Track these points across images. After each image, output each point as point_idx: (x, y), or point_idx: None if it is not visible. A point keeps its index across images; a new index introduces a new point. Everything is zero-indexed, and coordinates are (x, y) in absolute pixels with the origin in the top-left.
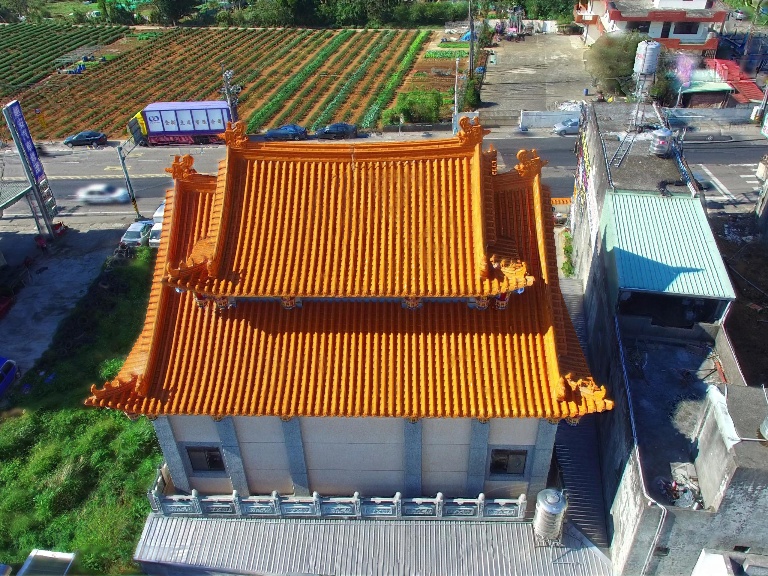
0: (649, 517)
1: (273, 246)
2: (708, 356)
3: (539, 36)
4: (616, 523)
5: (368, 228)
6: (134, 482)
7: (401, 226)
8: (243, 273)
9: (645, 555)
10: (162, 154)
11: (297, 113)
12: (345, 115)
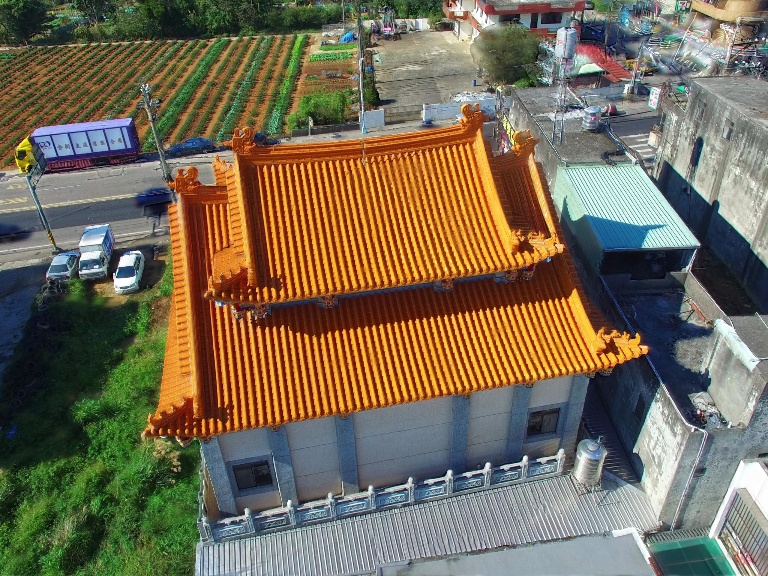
0: (692, 443)
1: (304, 248)
2: (683, 300)
3: (414, 34)
4: (646, 458)
5: (393, 219)
6: (149, 521)
7: (424, 214)
8: (282, 278)
9: (686, 479)
10: (59, 181)
11: (196, 126)
12: (248, 124)
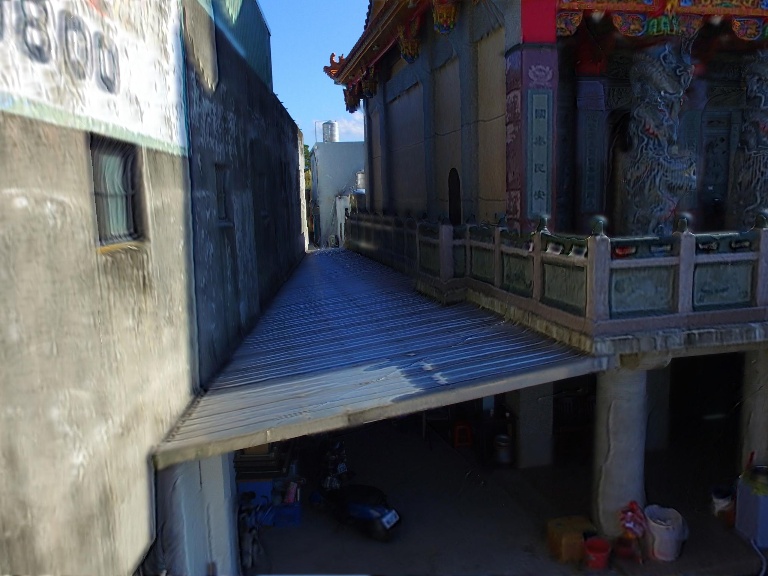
0: None
1: None
2: None
3: None
4: None
5: None
6: None
7: None
8: None
9: None
10: None
11: None
12: None
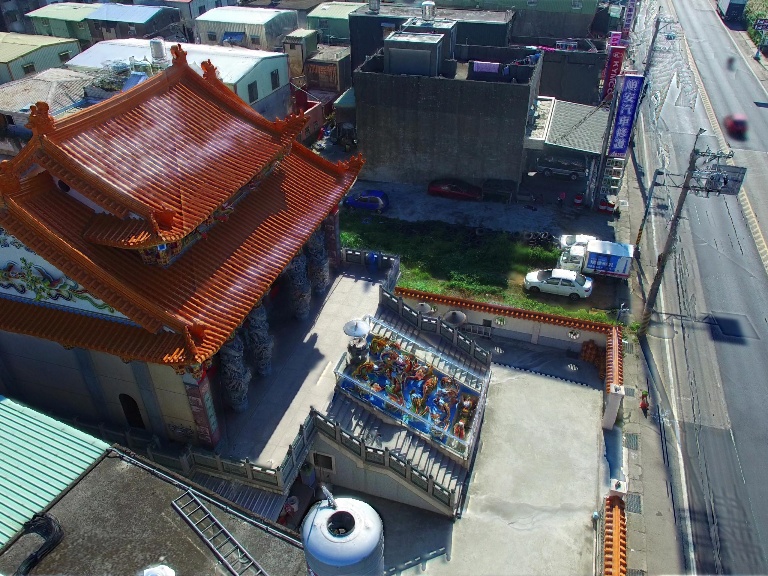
0: None
1: None
2: None
3: None
4: None
5: None
6: None
7: None
8: None
9: None
10: None
11: None
12: None
